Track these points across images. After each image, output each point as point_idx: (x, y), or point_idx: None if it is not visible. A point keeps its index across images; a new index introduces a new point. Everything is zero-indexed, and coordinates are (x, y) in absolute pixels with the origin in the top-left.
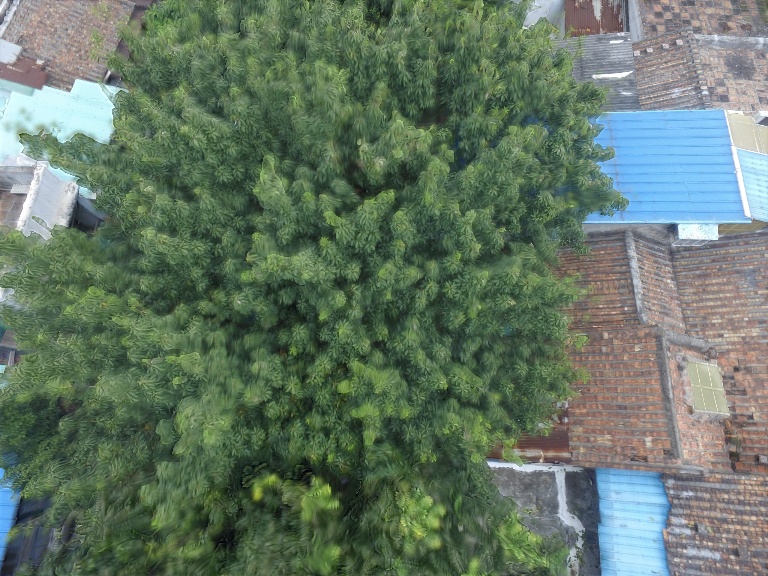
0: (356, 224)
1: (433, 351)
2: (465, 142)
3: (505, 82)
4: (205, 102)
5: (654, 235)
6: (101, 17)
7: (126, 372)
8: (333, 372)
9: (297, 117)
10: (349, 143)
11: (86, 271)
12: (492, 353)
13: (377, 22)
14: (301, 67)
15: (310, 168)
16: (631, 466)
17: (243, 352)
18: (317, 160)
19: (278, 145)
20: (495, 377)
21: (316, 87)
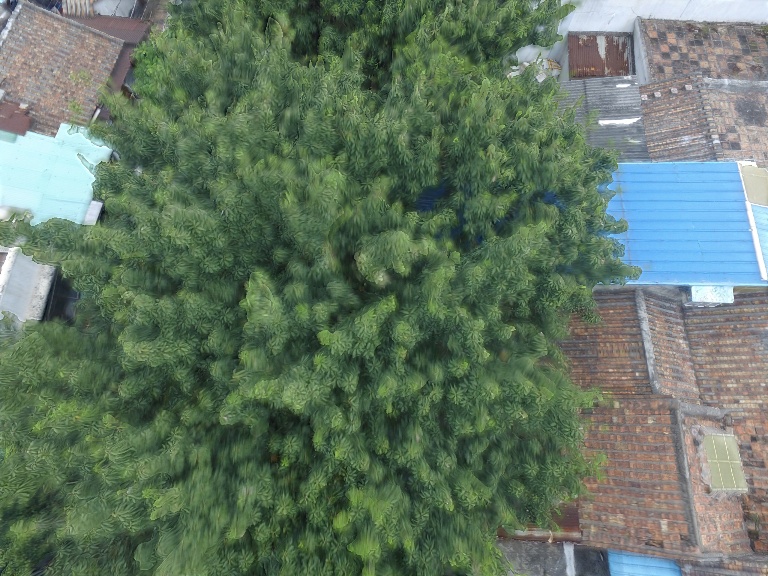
0: (353, 334)
1: (437, 461)
2: (470, 225)
3: (513, 161)
4: (190, 182)
5: (665, 293)
6: (88, 56)
7: (101, 497)
8: (329, 483)
9: (288, 215)
10: (345, 232)
11: (60, 371)
12: (500, 450)
13: (375, 74)
14: (293, 153)
15: (303, 264)
16: (646, 550)
17: (230, 465)
18: (311, 256)
19: (269, 230)
20: (503, 474)
21: (309, 188)
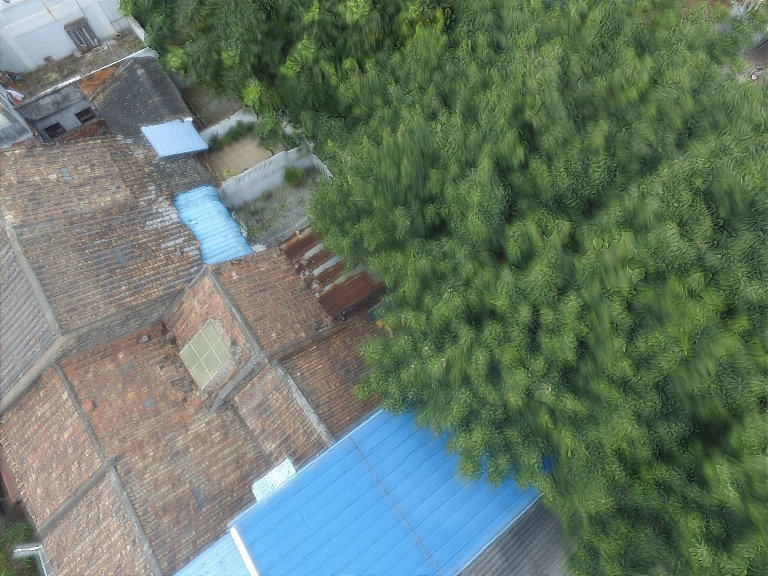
0: None
1: None
2: None
3: None
4: None
5: None
6: None
7: None
8: None
9: None
10: None
11: (642, 4)
12: None
13: None
14: None
15: None
16: None
17: None
18: None
19: None
20: None
21: None
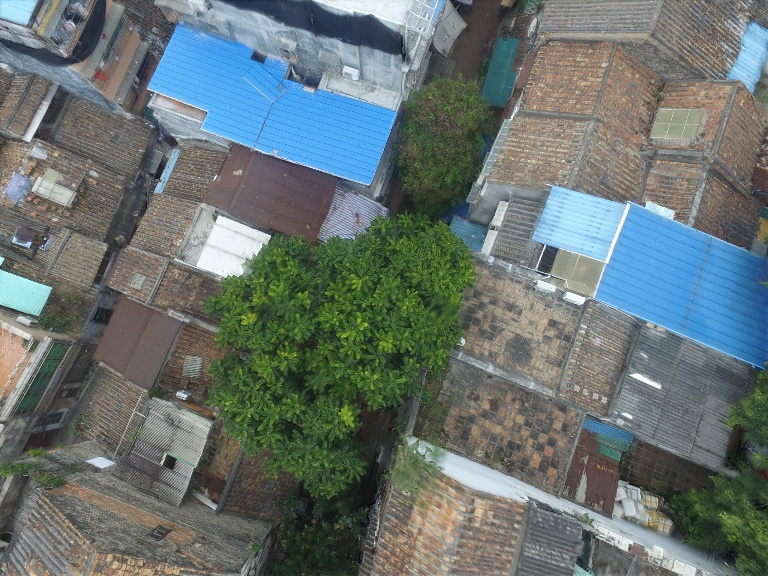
0: None
1: None
2: None
3: None
4: None
5: None
6: None
7: None
8: None
9: None
10: None
11: None
12: None
13: None
14: None
15: None
16: None
17: None
18: None
19: None
20: None
21: None
